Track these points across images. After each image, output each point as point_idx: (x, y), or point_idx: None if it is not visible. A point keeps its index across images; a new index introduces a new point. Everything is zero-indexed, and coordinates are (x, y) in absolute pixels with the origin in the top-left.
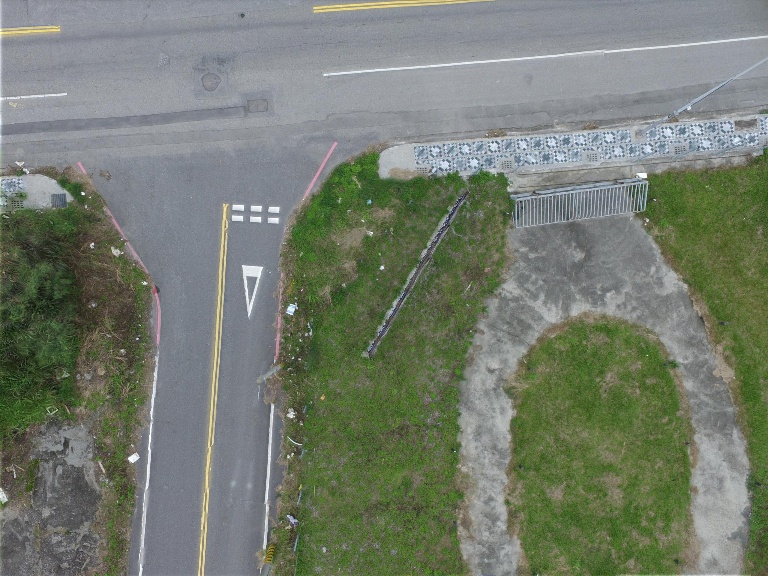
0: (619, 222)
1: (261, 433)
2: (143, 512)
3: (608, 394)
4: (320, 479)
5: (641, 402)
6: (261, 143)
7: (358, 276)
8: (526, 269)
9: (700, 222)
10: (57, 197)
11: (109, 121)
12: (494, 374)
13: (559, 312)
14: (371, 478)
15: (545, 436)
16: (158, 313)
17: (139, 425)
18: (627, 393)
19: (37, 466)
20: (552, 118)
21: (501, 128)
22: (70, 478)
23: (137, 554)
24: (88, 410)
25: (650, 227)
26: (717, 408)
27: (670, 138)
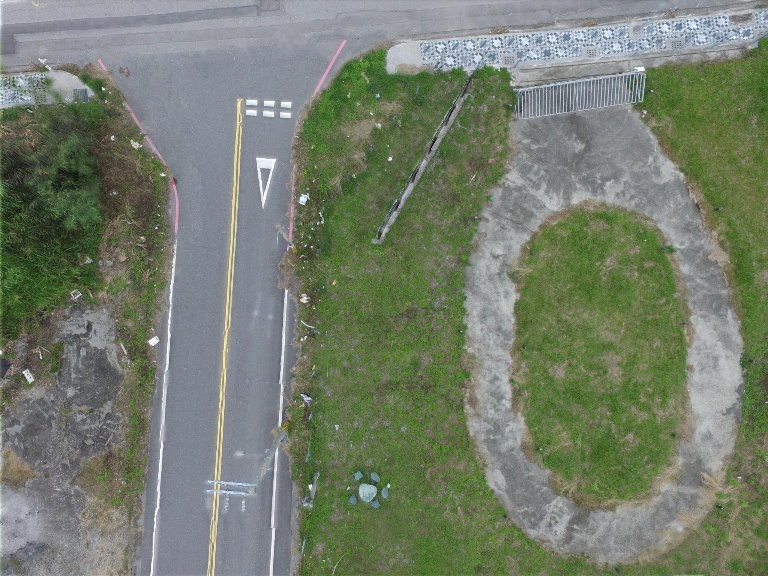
0: (618, 114)
1: (275, 317)
2: (163, 391)
3: (608, 277)
4: (332, 360)
5: (639, 284)
6: (273, 41)
7: (367, 167)
8: (528, 160)
9: (696, 113)
10: (78, 91)
11: (127, 20)
12: (498, 260)
13: (560, 200)
14: (381, 359)
15: (547, 317)
16: (176, 204)
17: (159, 310)
18: (626, 276)
19: (62, 348)
20: (553, 15)
21: (504, 26)
22: (93, 359)
23: (158, 432)
24: (110, 295)
25: (648, 119)
26: (712, 290)
27: (667, 33)
